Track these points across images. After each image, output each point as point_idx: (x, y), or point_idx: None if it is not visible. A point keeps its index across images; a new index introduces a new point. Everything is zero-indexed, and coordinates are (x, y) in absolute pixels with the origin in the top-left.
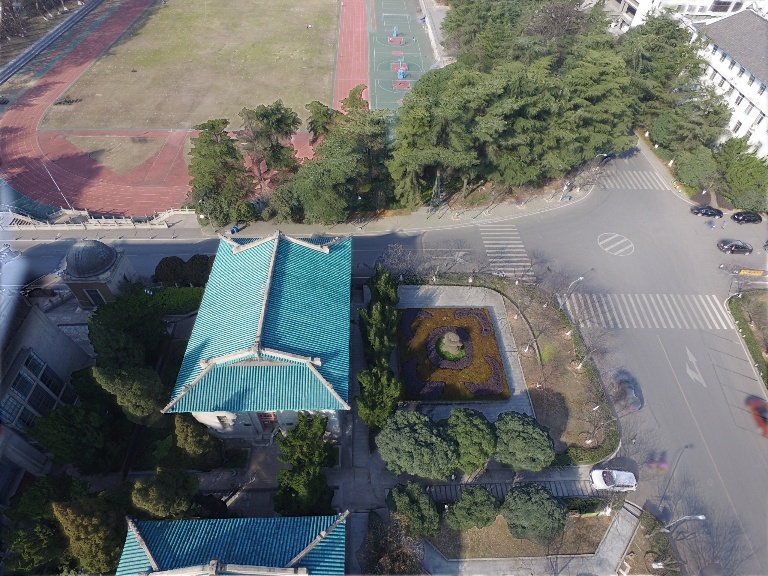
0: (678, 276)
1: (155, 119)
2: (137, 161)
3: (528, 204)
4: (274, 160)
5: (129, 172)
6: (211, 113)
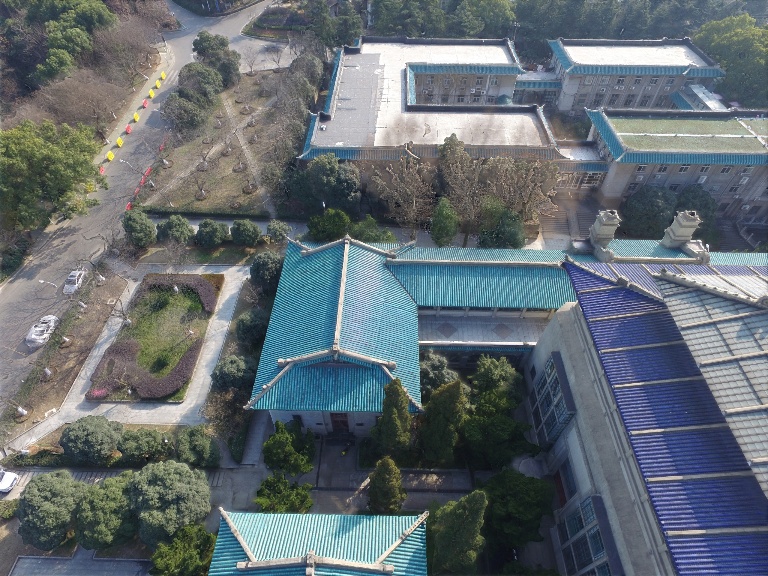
0: None
1: None
2: None
3: None
4: None
5: None
6: None
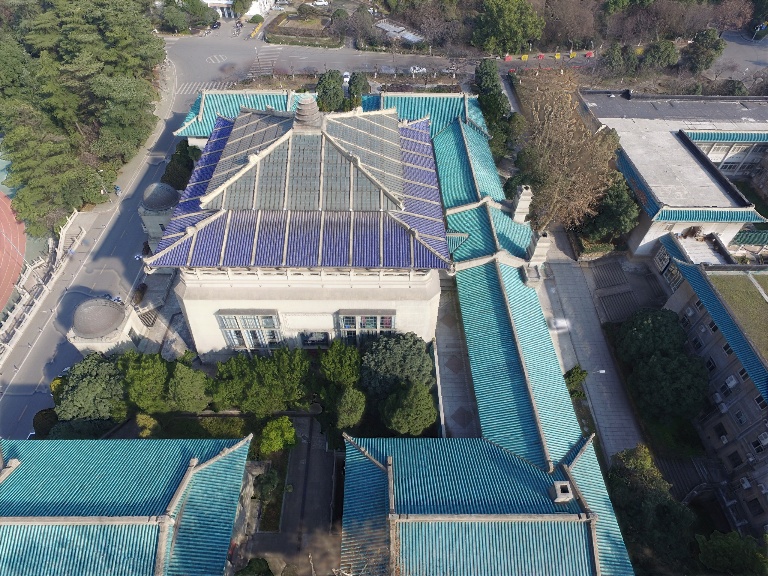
0: (247, 49)
1: None
2: None
3: None
4: None
5: None
6: None
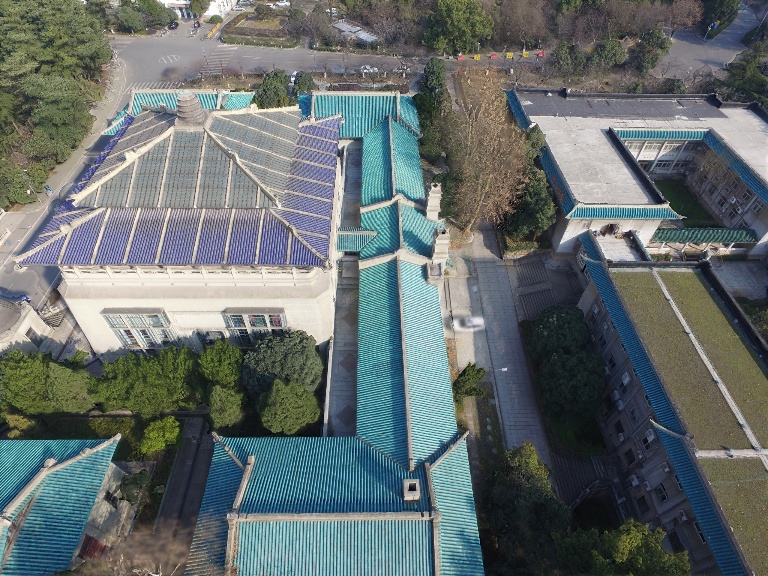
0: None
1: None
2: None
3: (116, 76)
4: None
5: None
6: None
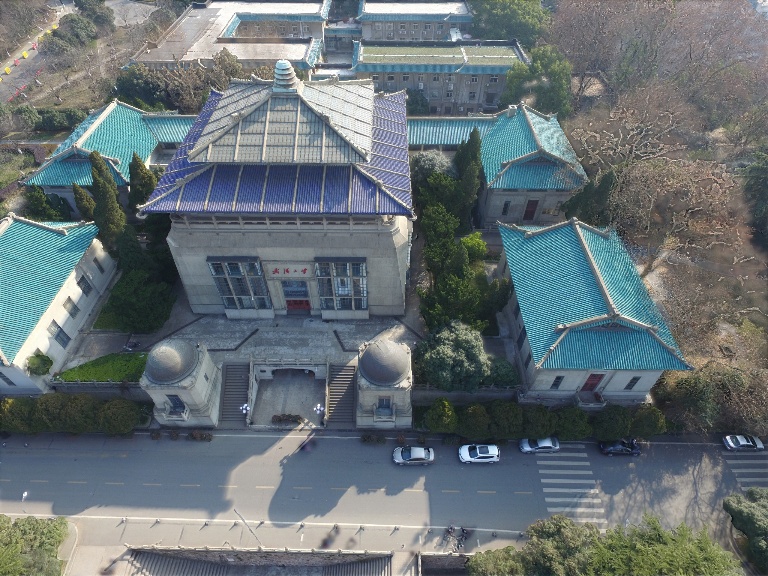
0: None
1: None
2: None
3: None
4: None
5: None
6: None
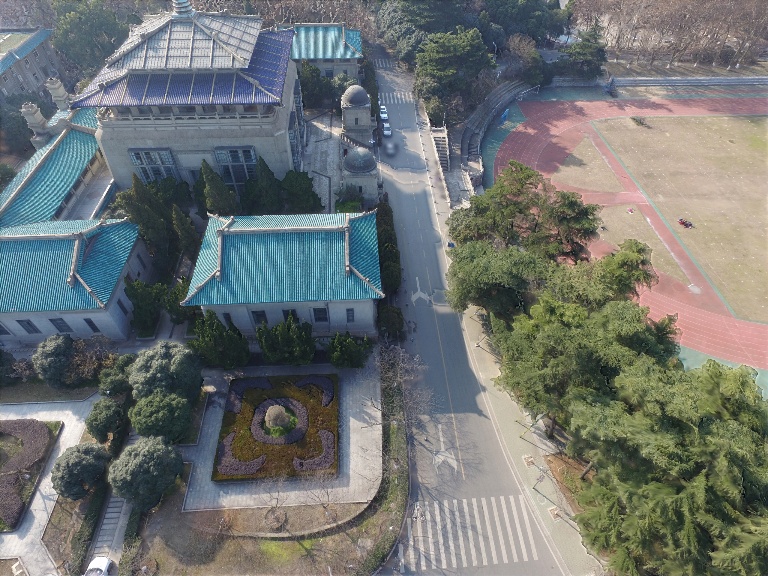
0: None
1: (653, 176)
2: (576, 183)
3: None
4: (535, 240)
5: (558, 183)
6: (696, 211)
